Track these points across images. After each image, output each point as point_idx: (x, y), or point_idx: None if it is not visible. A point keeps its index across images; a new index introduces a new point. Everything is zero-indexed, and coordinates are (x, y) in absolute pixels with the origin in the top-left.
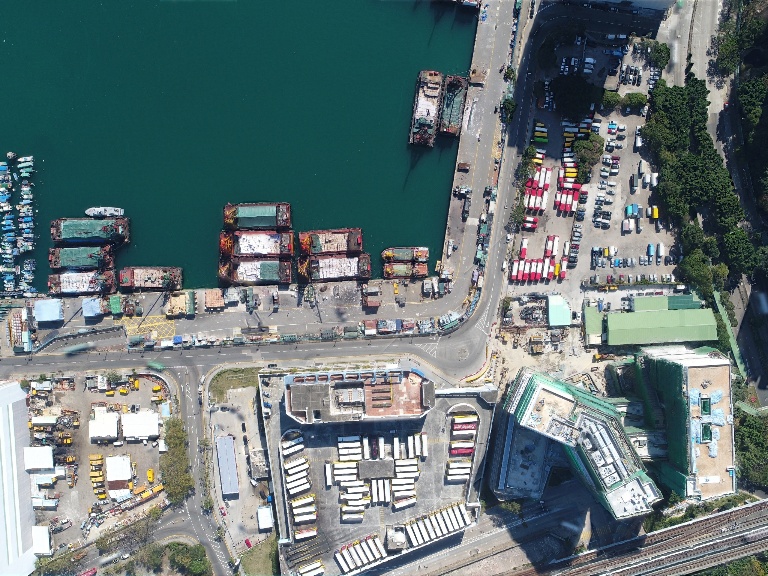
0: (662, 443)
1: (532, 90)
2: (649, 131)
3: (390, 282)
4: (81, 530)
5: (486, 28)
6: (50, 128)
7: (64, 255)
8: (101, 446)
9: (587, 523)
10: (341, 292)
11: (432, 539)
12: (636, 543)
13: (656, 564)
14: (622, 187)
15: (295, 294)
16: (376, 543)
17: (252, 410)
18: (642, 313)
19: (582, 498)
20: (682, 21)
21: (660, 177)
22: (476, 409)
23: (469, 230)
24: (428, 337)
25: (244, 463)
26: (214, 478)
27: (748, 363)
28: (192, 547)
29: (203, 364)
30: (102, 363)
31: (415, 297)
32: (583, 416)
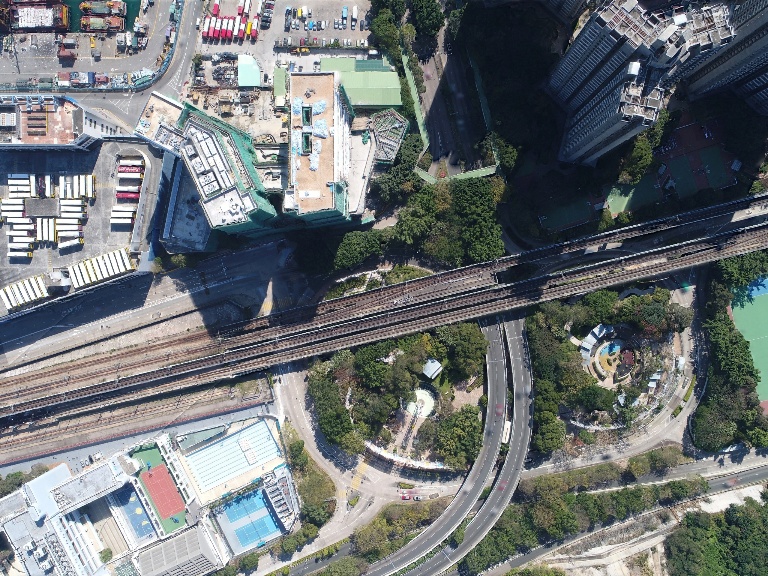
0: None
1: None
2: None
3: (87, 36)
4: None
5: None
6: None
7: None
8: None
9: (269, 293)
10: (40, 44)
11: (96, 284)
12: (308, 311)
13: (327, 334)
14: None
15: None
16: (38, 282)
17: None
18: None
19: (265, 267)
20: None
21: None
22: (148, 157)
23: None
24: (121, 93)
25: None
26: None
27: (440, 137)
28: None
29: None
30: None
31: (111, 52)
32: (189, 123)
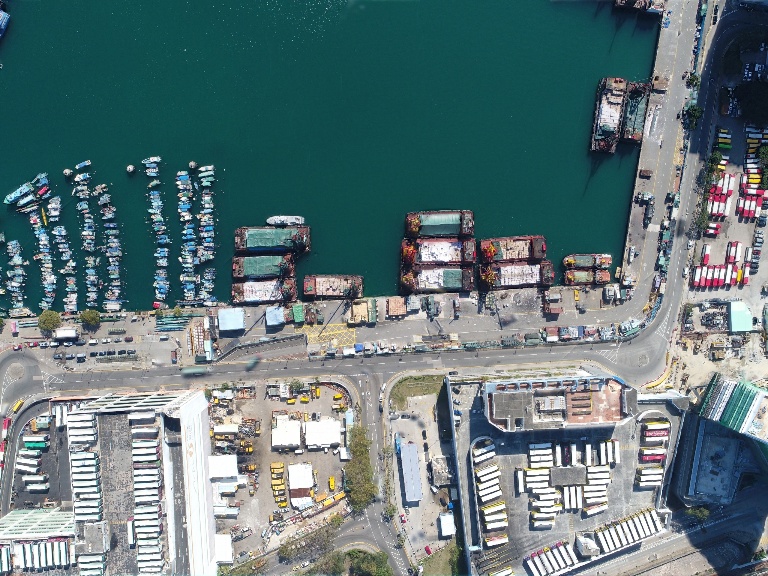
0: None
1: (714, 96)
2: None
3: (571, 289)
4: (261, 538)
5: (669, 35)
6: (231, 137)
7: (248, 264)
8: (281, 454)
9: (766, 528)
10: (522, 299)
11: (622, 545)
12: None
13: None
14: None
15: (476, 301)
16: (568, 550)
17: (432, 417)
18: None
19: (761, 503)
20: None
21: None
22: None
23: (650, 236)
24: (608, 343)
25: (424, 470)
26: (394, 485)
27: None
28: (375, 554)
29: (384, 372)
30: (283, 371)
31: (596, 304)
32: None
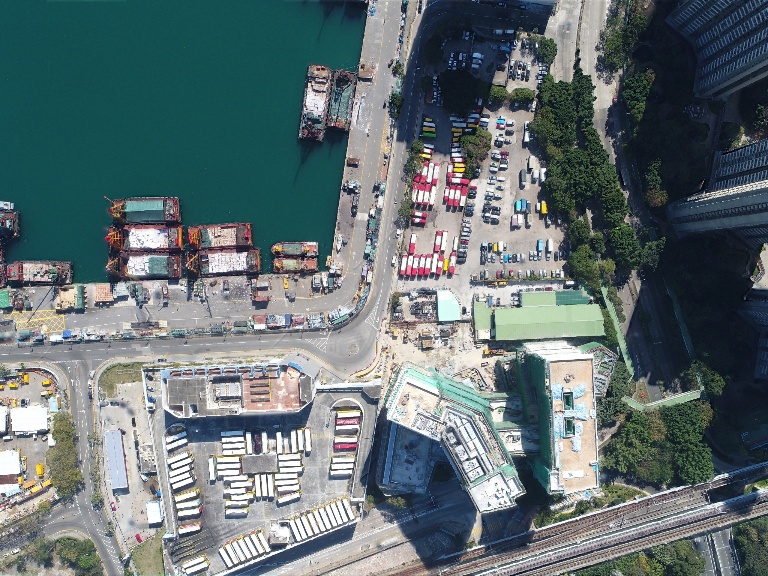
0: (536, 438)
1: (421, 85)
2: (535, 126)
3: (280, 277)
4: None
5: (375, 23)
6: None
7: None
8: None
9: (478, 519)
10: (231, 287)
11: (317, 534)
12: (524, 539)
13: (544, 560)
14: (511, 182)
15: (185, 289)
16: (259, 538)
17: (142, 405)
18: (529, 308)
19: None
20: (570, 16)
21: (547, 172)
22: (361, 404)
23: (359, 225)
24: (318, 332)
25: (134, 458)
26: (104, 473)
27: (638, 359)
28: (81, 542)
29: (93, 358)
30: None
31: (305, 292)
32: (448, 410)
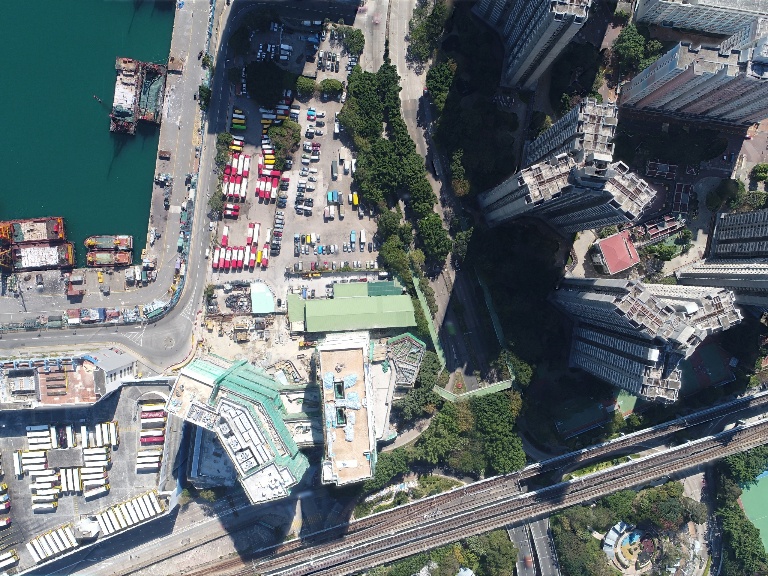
0: None
1: None
2: (341, 117)
3: (94, 271)
4: None
5: (183, 15)
6: None
7: None
8: None
9: (298, 511)
10: (45, 281)
11: (126, 528)
12: (340, 531)
13: (360, 552)
14: (324, 174)
15: None
16: (66, 533)
17: None
18: (340, 300)
19: None
20: (379, 7)
21: (356, 163)
22: None
23: (172, 218)
24: (134, 326)
25: None
26: None
27: (454, 349)
28: None
29: None
30: None
31: (120, 286)
32: (222, 401)
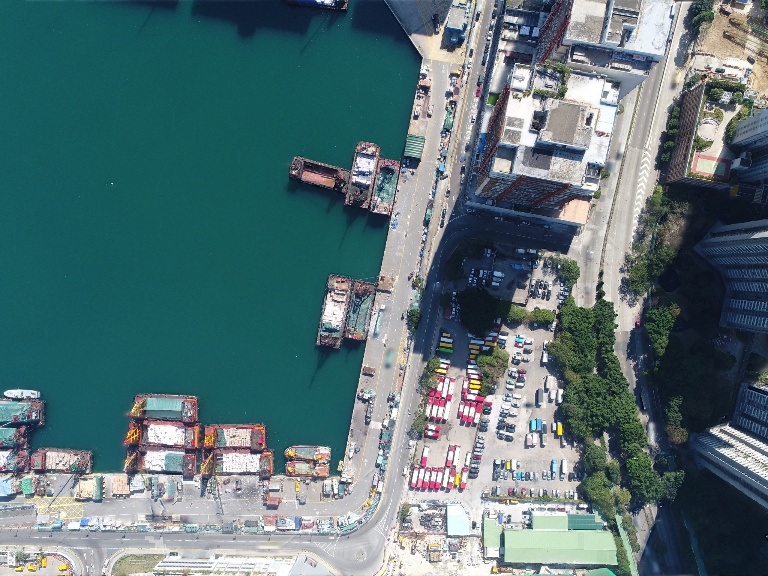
0: None
1: None
2: (554, 351)
3: (292, 479)
4: None
5: (396, 235)
6: None
7: None
8: None
9: None
10: (244, 486)
11: None
12: None
13: None
14: (527, 400)
15: (199, 485)
16: None
17: None
18: (540, 533)
19: None
20: (595, 237)
21: (564, 396)
22: None
23: (372, 433)
24: (327, 536)
25: None
26: None
27: None
28: None
29: (108, 547)
30: (13, 539)
31: (316, 496)
32: None
